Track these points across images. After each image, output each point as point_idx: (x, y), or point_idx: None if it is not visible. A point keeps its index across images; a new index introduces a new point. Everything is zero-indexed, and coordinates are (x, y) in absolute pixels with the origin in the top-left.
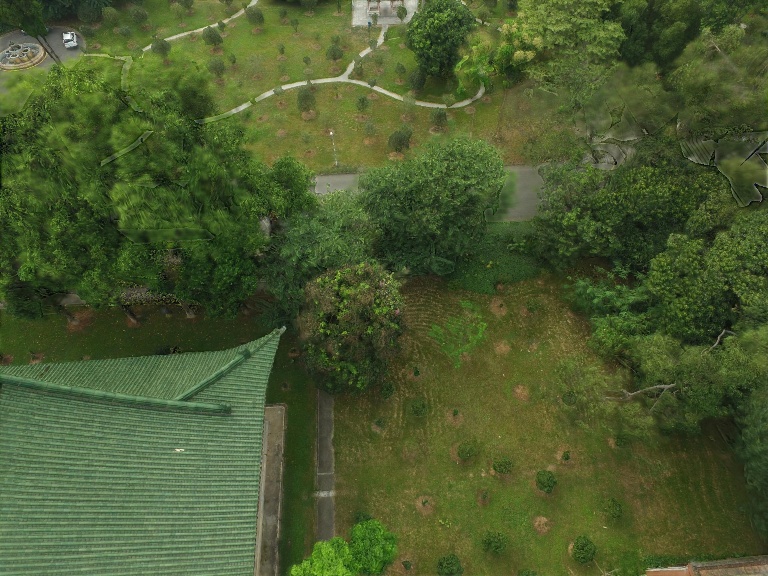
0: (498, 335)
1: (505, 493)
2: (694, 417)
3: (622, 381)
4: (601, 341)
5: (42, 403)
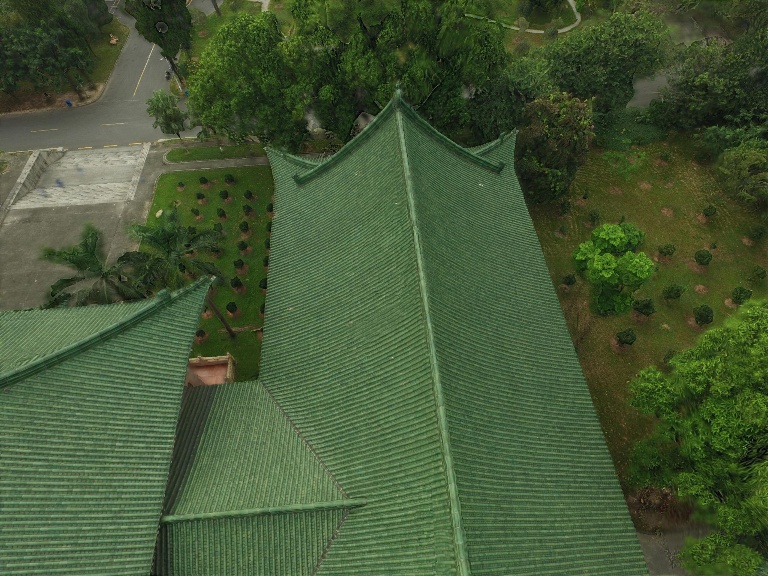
0: (640, 178)
1: (669, 272)
2: None
3: (747, 203)
4: (739, 159)
5: None
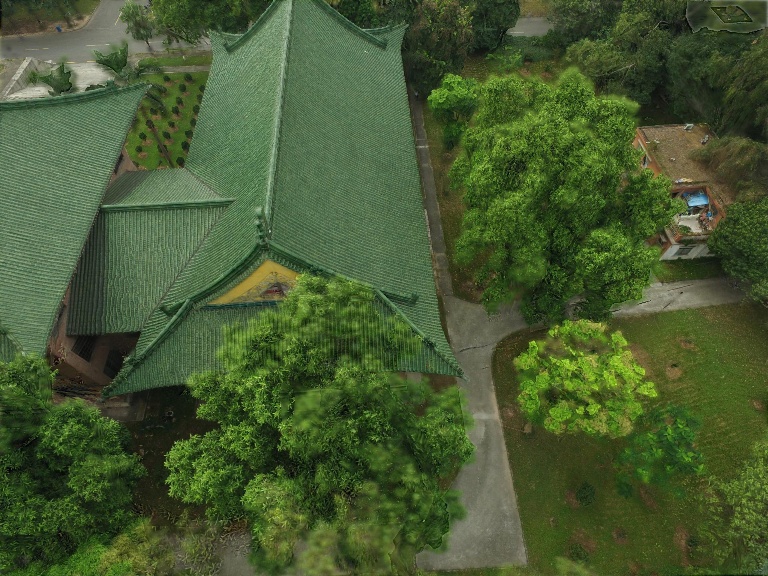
0: None
1: None
2: (643, 66)
3: None
4: None
5: None
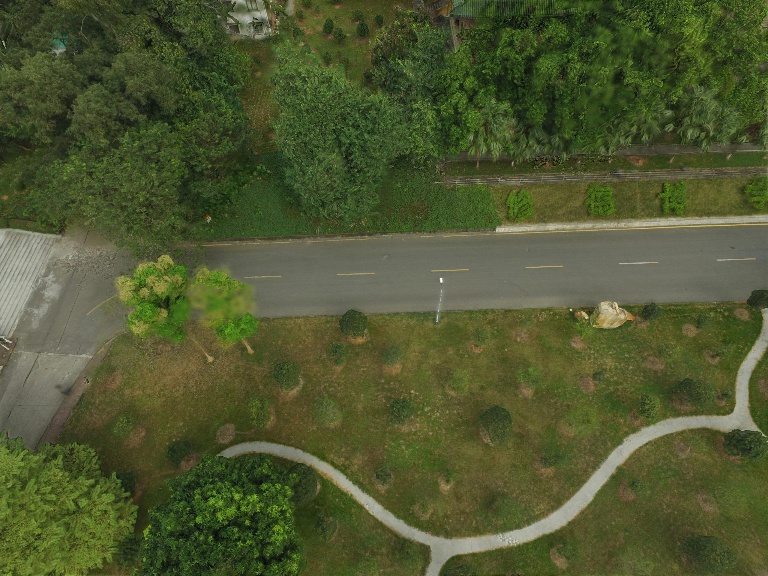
0: None
1: None
2: None
3: None
4: None
5: None
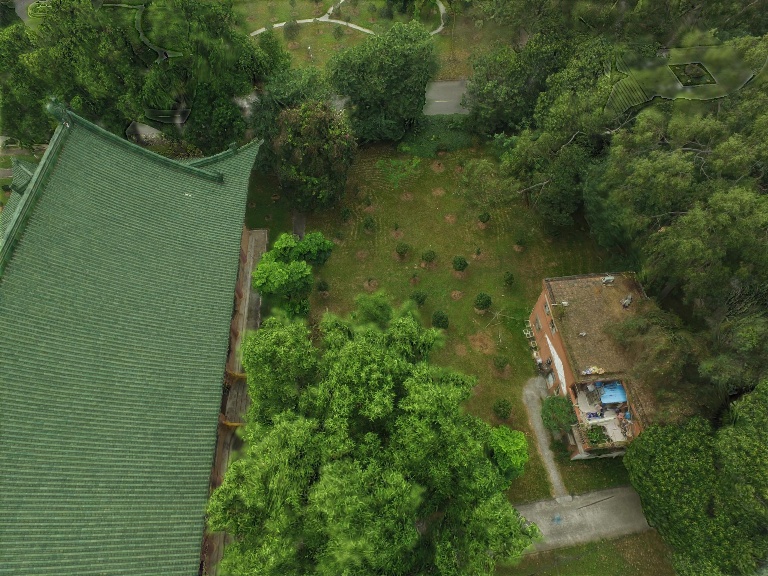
0: (436, 184)
1: (431, 278)
2: (555, 191)
3: (528, 209)
4: (504, 167)
5: (98, 143)
